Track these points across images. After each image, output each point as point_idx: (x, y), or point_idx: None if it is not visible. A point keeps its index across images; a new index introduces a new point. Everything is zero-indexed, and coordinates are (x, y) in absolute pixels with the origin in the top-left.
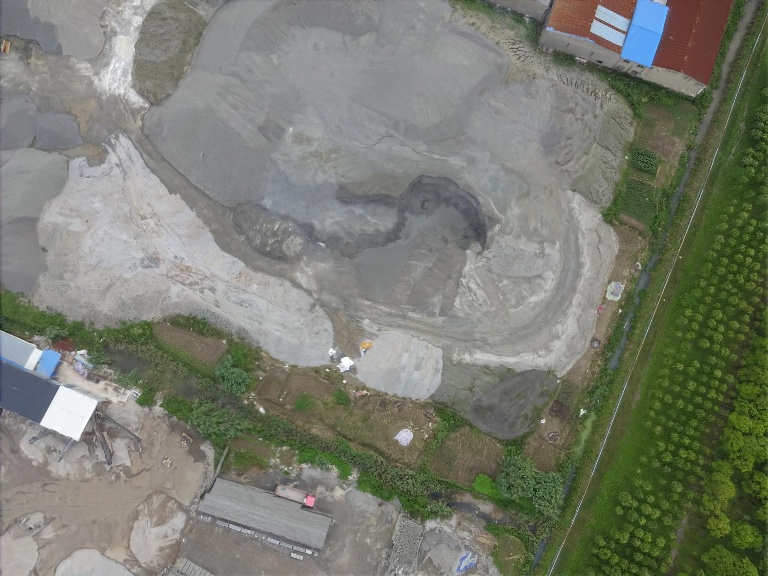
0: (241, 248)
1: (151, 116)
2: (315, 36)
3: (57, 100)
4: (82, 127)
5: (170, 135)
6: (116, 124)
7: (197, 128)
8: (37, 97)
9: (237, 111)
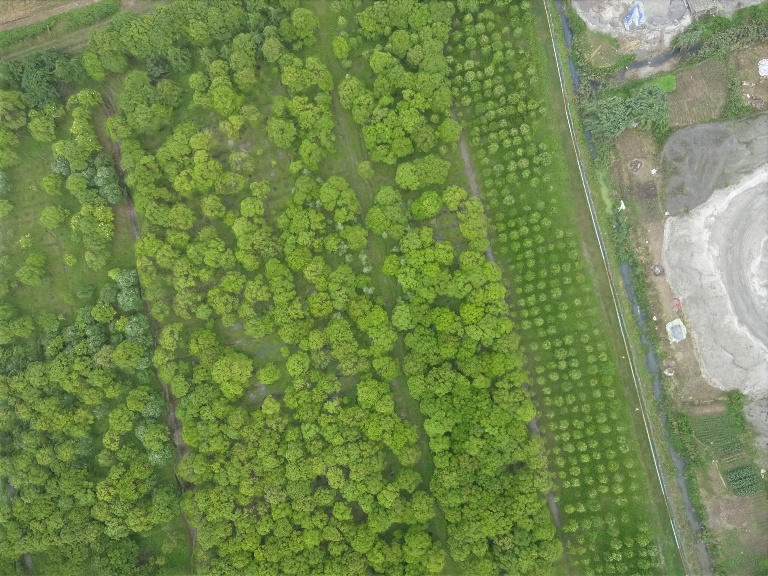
0: None
1: None
2: None
3: None
4: None
5: None
6: None
7: None
8: None
9: None
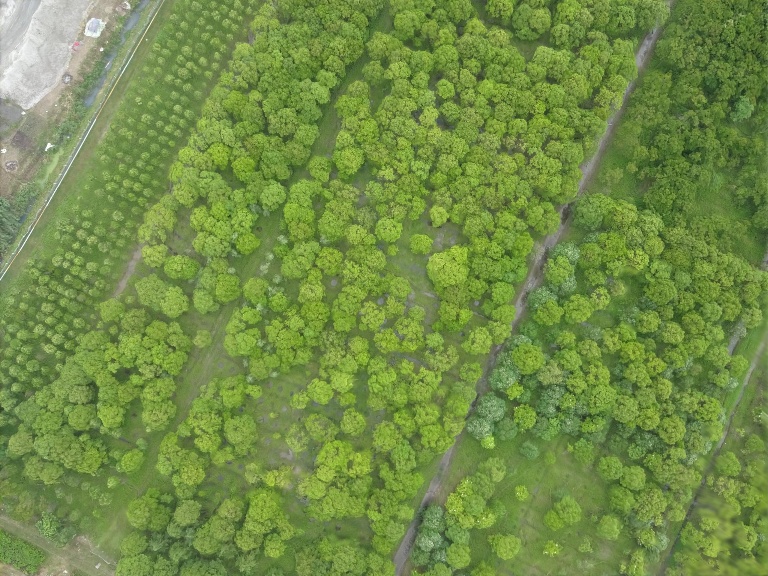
0: None
1: None
2: None
3: None
4: None
5: None
6: None
7: None
8: None
9: None
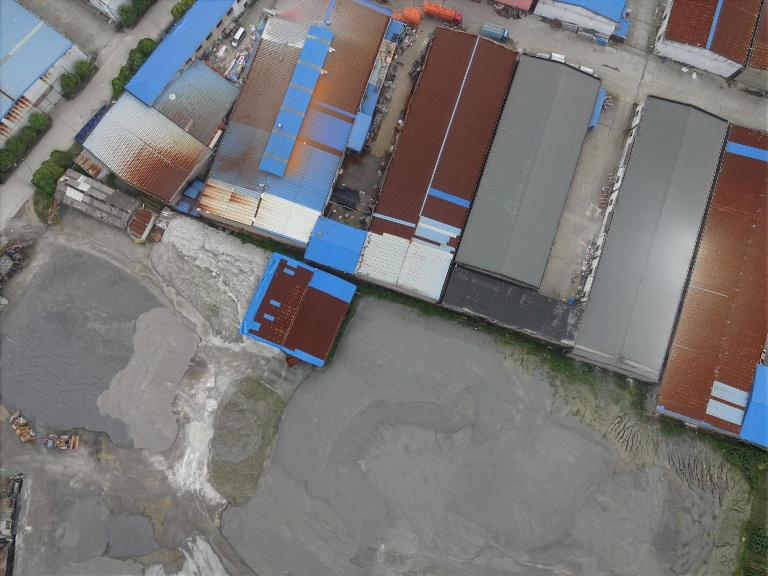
0: None
1: (230, 520)
2: (405, 435)
3: (130, 500)
4: (157, 529)
5: (252, 546)
6: (193, 525)
7: (283, 553)
8: (109, 498)
9: (327, 543)
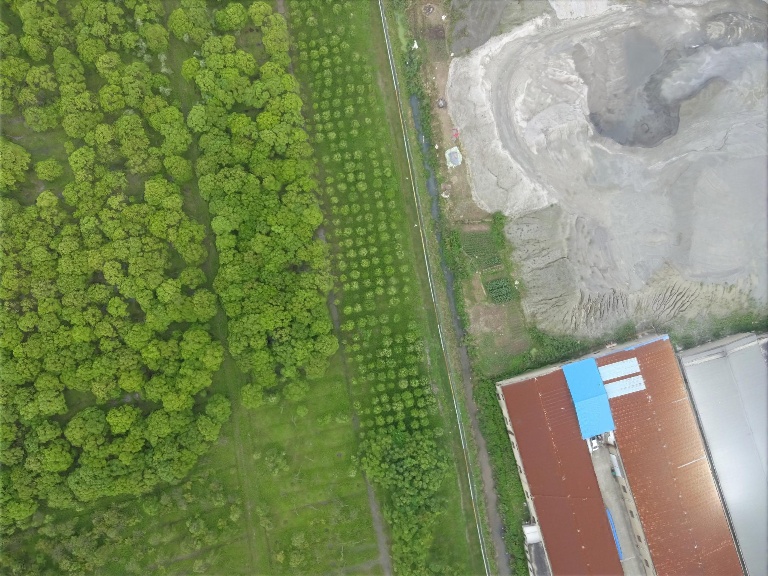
0: (745, 8)
1: None
2: None
3: None
4: None
5: None
6: None
7: None
8: None
9: None
